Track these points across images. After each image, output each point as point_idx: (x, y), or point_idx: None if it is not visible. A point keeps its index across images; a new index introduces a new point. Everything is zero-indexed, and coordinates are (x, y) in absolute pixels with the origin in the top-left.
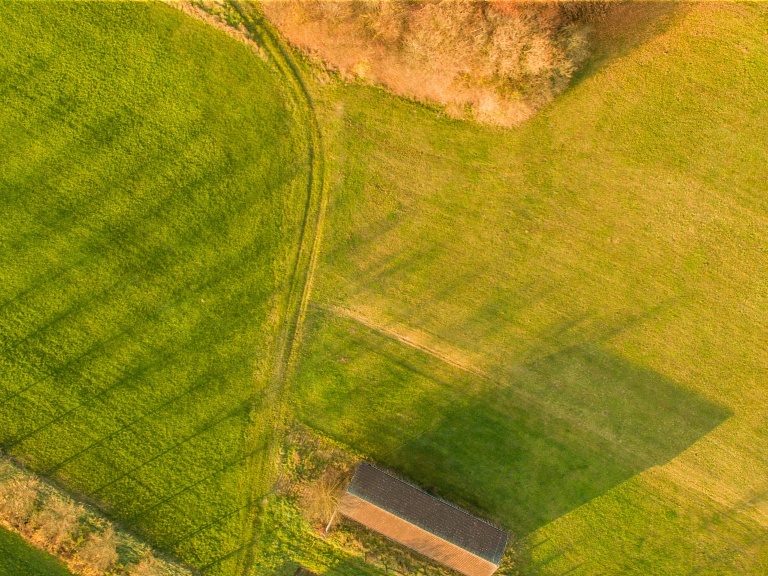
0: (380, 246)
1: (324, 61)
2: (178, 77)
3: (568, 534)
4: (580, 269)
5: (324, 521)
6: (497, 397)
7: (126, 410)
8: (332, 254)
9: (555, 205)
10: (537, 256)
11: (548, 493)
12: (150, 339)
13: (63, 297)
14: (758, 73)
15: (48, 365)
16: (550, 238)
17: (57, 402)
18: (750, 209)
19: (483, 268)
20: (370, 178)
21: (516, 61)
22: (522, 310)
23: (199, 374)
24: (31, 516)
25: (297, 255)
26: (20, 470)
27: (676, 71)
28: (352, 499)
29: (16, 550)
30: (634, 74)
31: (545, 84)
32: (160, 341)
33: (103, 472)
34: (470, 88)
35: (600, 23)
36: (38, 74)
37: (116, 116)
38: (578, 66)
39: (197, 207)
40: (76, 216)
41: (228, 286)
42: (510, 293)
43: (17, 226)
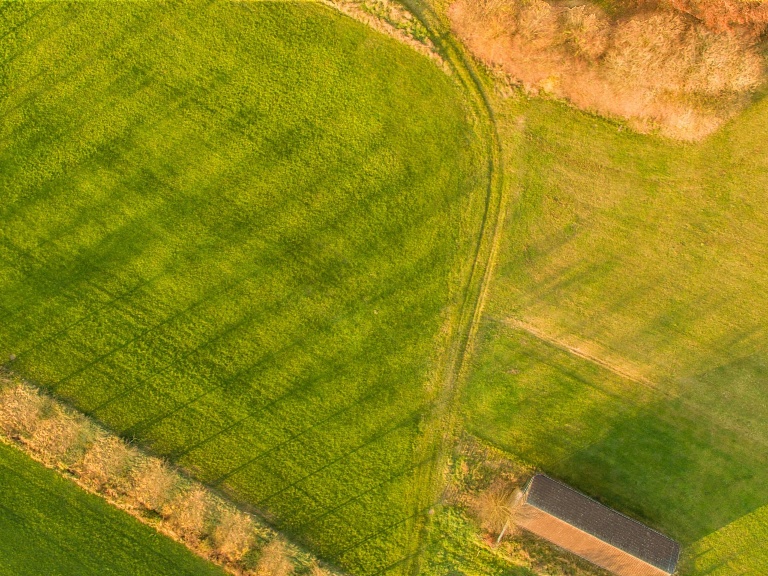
0: (556, 258)
1: (508, 75)
2: (361, 90)
3: (731, 543)
4: (754, 281)
5: (495, 531)
6: (665, 408)
7: (294, 421)
8: (508, 266)
9: (732, 218)
10: (712, 268)
11: (713, 503)
12: (321, 350)
13: (235, 308)
14: None
15: (218, 376)
16: (725, 251)
17: (226, 413)
18: None
19: (658, 280)
20: (548, 191)
21: (703, 76)
22: (694, 322)
23: (369, 385)
24: (196, 526)
25: (472, 267)
26: (187, 481)
27: None
28: (530, 510)
29: (181, 560)
30: None
31: (729, 99)
32: (331, 352)
33: (270, 482)
34: (656, 103)
35: None
36: (220, 87)
37: (297, 129)
38: (762, 81)
39: (374, 219)
40: (252, 228)
41: (402, 298)
42: (683, 305)
43: (192, 238)
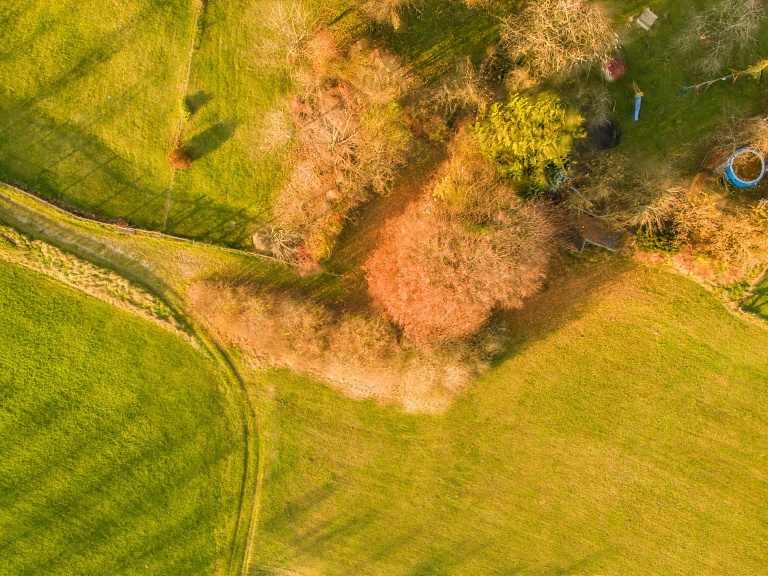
0: (316, 513)
1: (254, 348)
2: (112, 365)
3: None
4: (509, 528)
5: None
6: None
7: None
8: (270, 522)
9: (483, 472)
10: (468, 518)
11: None
12: None
13: (9, 567)
14: (670, 352)
15: None
16: (479, 501)
17: None
18: (668, 471)
19: (416, 530)
20: (304, 452)
21: (438, 350)
22: (455, 566)
23: None
24: None
25: (236, 523)
26: None
27: (592, 352)
28: None
29: None
30: (552, 355)
31: (468, 367)
32: None
33: None
34: (395, 375)
35: (518, 310)
36: None
37: (53, 401)
38: (499, 349)
39: (137, 482)
40: (18, 493)
41: (171, 553)
42: (443, 551)
43: None
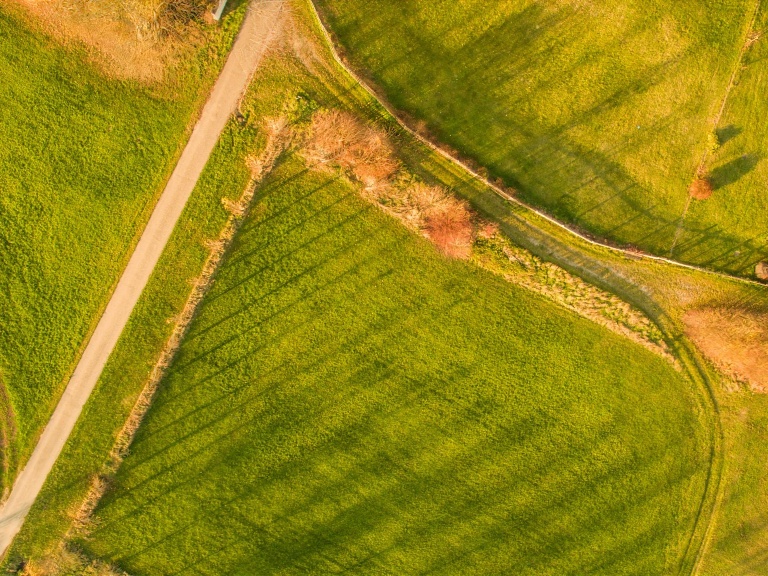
0: None
1: (735, 373)
2: (594, 384)
3: None
4: None
5: None
6: None
7: None
8: (723, 541)
9: None
10: None
11: None
12: None
13: None
14: None
15: None
16: None
17: None
18: None
19: None
20: (765, 474)
21: None
22: None
23: None
24: None
25: (689, 541)
26: None
27: None
28: None
29: None
30: None
31: None
32: None
33: None
34: None
35: None
36: (458, 380)
37: (530, 418)
38: None
39: (599, 498)
40: (481, 506)
41: (621, 568)
42: None
43: (423, 514)
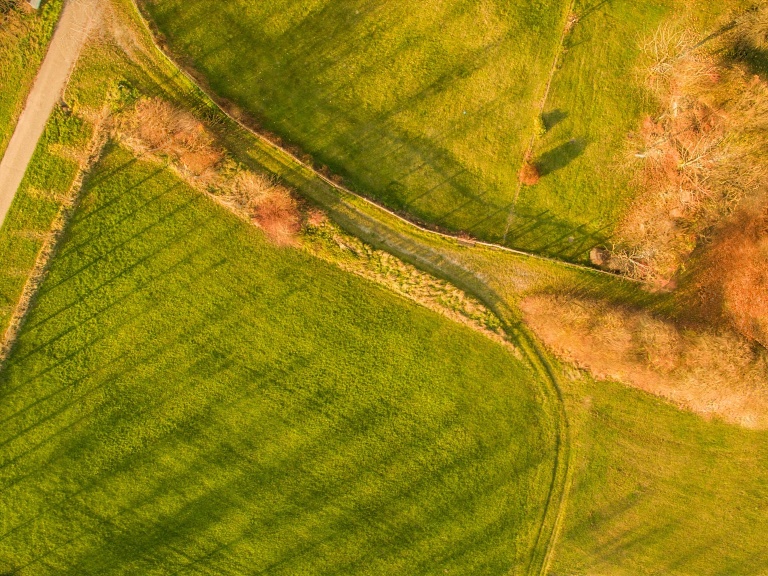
0: (619, 522)
1: (576, 360)
2: (435, 373)
3: None
4: None
5: None
6: None
7: None
8: (573, 530)
9: None
10: (765, 529)
11: None
12: None
13: (311, 569)
14: None
15: None
16: None
17: None
18: None
19: (714, 541)
20: (613, 462)
21: None
22: None
23: None
24: None
25: (539, 530)
26: None
27: None
28: None
29: None
30: None
31: None
32: None
33: None
34: (717, 389)
35: None
36: (298, 369)
37: (372, 408)
38: None
39: (446, 488)
40: (328, 497)
41: (471, 558)
42: (737, 562)
43: (269, 506)
